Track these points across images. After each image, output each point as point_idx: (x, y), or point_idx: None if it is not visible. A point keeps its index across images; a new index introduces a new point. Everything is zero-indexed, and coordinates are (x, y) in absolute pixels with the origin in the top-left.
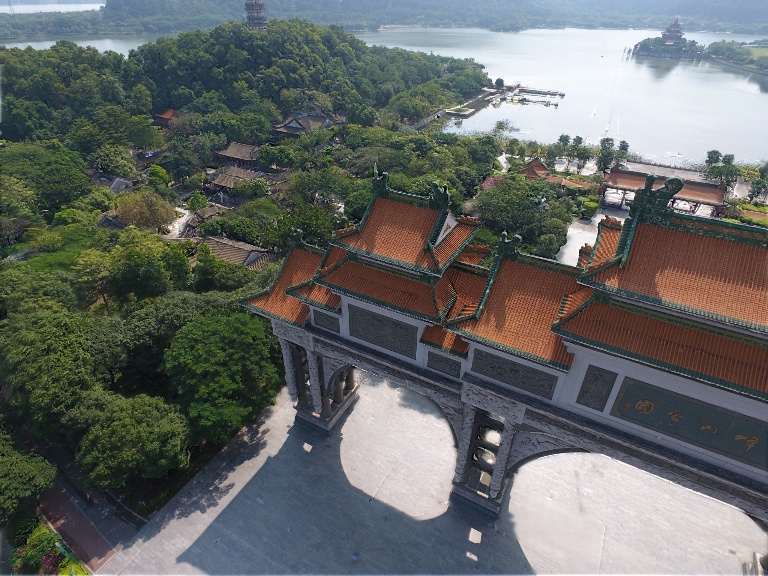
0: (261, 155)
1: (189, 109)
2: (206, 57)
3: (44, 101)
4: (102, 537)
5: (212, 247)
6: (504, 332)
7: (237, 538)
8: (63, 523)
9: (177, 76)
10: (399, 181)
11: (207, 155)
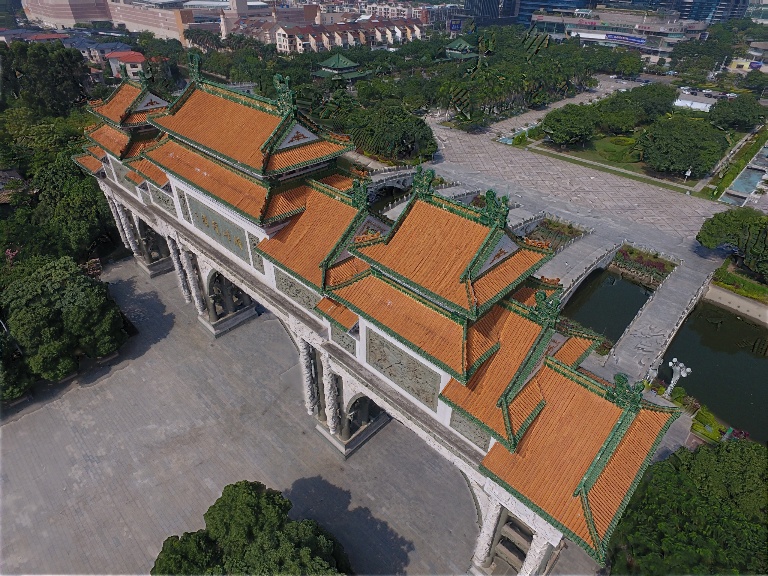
0: None
1: None
2: None
3: None
4: None
5: None
6: None
7: None
8: None
9: None
10: None
11: None
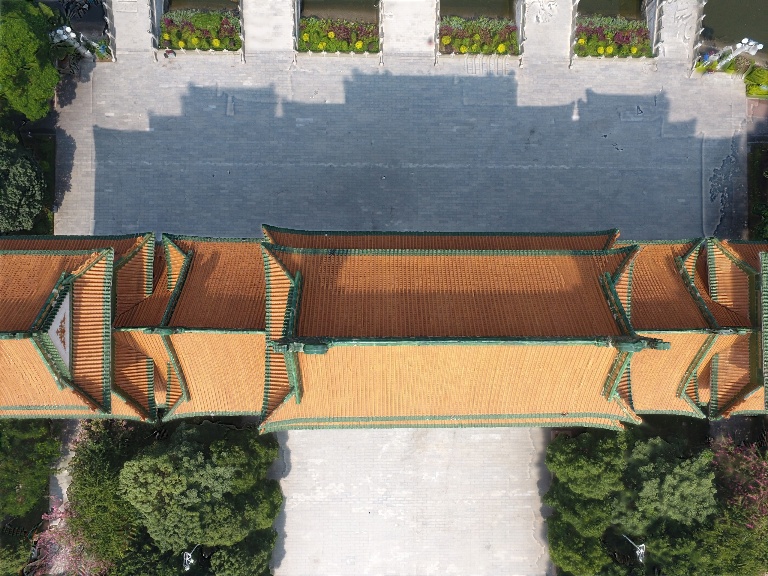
0: None
1: None
2: None
3: None
4: (767, 117)
5: None
6: (642, 256)
7: (676, 167)
8: None
9: None
10: None
11: None
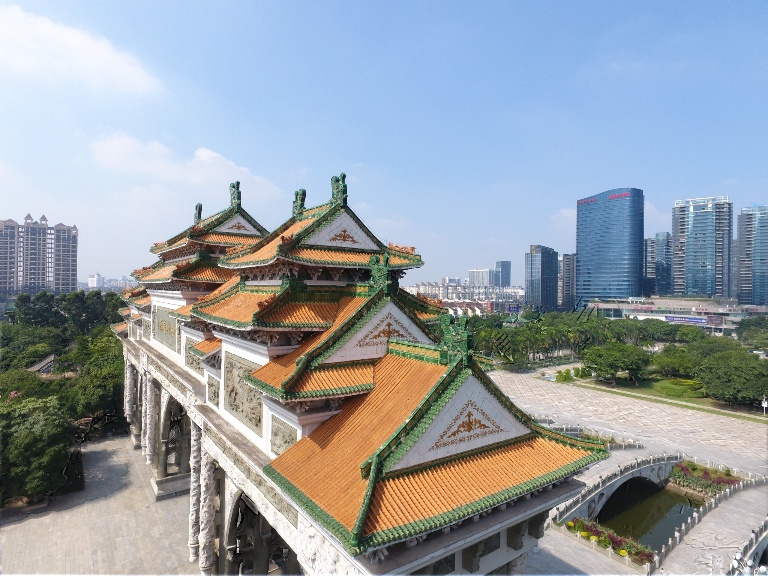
0: None
1: None
2: None
3: None
4: None
5: None
6: None
7: None
8: None
9: None
10: None
11: None
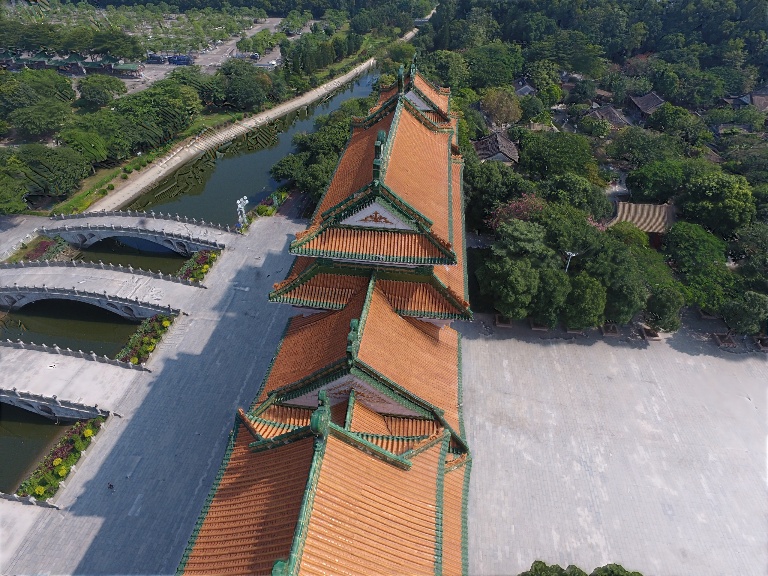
0: (656, 110)
1: (661, 55)
2: (729, 7)
3: (558, 21)
4: (289, 211)
5: (491, 140)
6: None
7: None
8: (290, 199)
9: (688, 22)
10: (699, 168)
11: (619, 96)
